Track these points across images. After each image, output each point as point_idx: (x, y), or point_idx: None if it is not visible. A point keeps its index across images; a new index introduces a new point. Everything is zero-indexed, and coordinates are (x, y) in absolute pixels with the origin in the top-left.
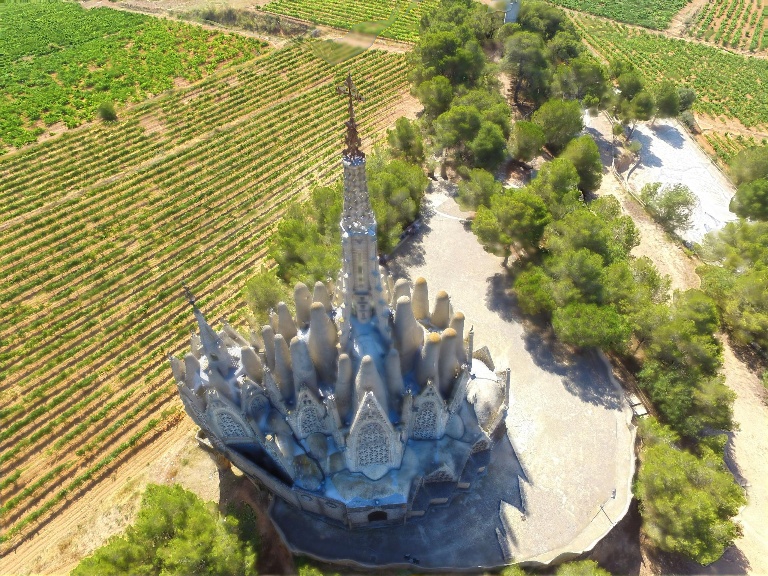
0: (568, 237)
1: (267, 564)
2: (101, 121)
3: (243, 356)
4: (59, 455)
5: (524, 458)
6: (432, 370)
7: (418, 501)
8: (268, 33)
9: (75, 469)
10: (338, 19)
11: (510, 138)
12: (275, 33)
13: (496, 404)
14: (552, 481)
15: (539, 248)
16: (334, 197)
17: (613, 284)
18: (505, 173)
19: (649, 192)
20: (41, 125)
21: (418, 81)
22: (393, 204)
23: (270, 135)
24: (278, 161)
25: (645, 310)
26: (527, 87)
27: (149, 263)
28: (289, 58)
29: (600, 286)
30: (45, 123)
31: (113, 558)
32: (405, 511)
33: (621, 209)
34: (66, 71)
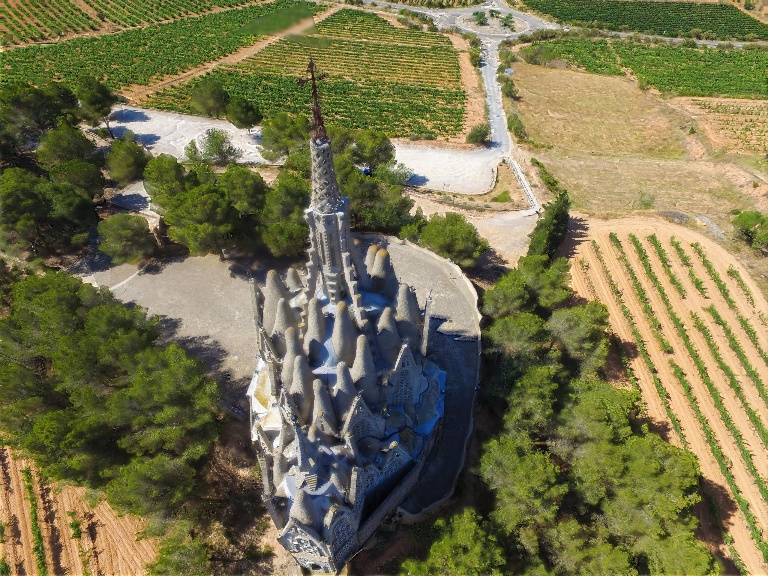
0: (243, 196)
1: None
2: None
3: (318, 436)
4: None
5: None
6: None
7: None
8: None
9: None
10: None
11: None
12: None
13: None
14: None
15: (241, 218)
16: None
17: None
18: None
19: (192, 152)
20: None
21: None
22: None
23: None
24: None
25: None
26: None
27: None
28: None
29: None
30: None
31: None
32: None
33: None
34: None
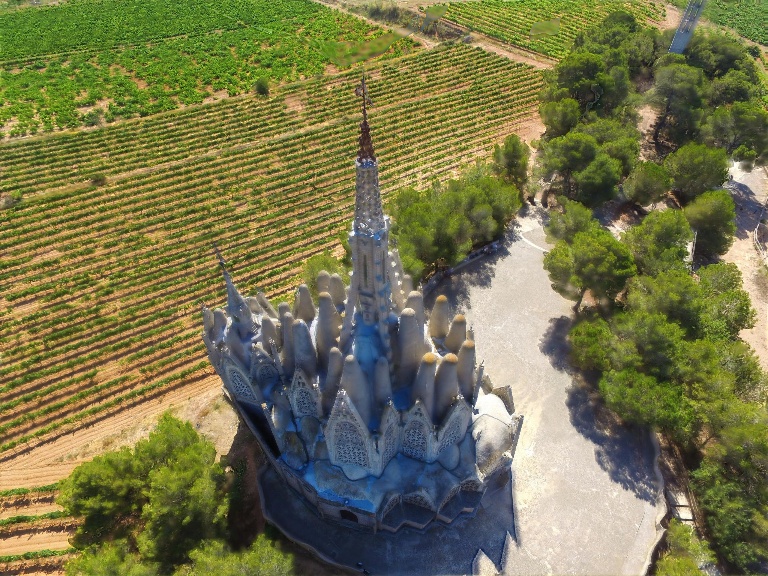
0: (653, 297)
1: (246, 521)
2: (255, 94)
3: (262, 325)
4: (129, 367)
5: (521, 515)
6: (424, 390)
7: (391, 516)
8: (424, 34)
9: (136, 383)
10: (495, 28)
11: (629, 177)
12: (430, 35)
13: (500, 448)
14: (543, 551)
15: (614, 301)
16: (418, 200)
17: (692, 363)
18: (614, 213)
19: None
20: (210, 89)
21: (549, 101)
22: (472, 219)
23: (391, 131)
24: (389, 156)
25: (719, 402)
26: (675, 126)
27: (249, 225)
28: (434, 60)
29: (669, 360)
30: (213, 88)
31: (116, 464)
32: (374, 521)
33: (747, 283)
34: (243, 46)
